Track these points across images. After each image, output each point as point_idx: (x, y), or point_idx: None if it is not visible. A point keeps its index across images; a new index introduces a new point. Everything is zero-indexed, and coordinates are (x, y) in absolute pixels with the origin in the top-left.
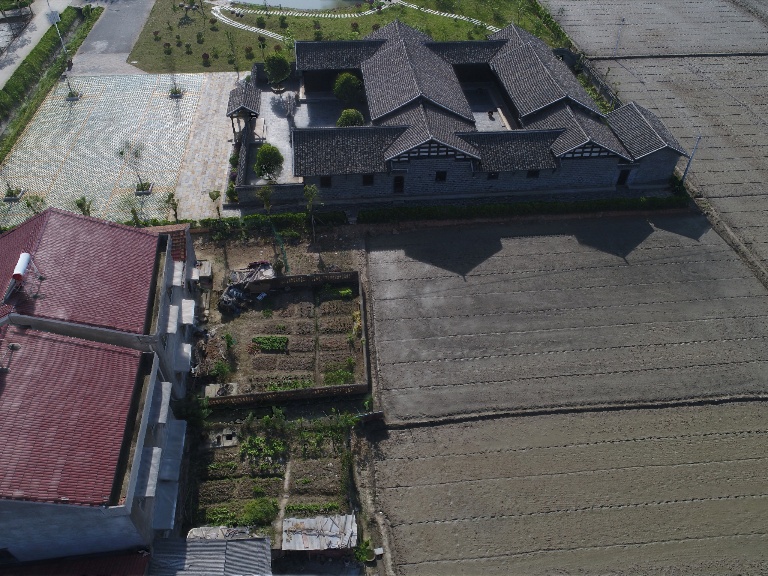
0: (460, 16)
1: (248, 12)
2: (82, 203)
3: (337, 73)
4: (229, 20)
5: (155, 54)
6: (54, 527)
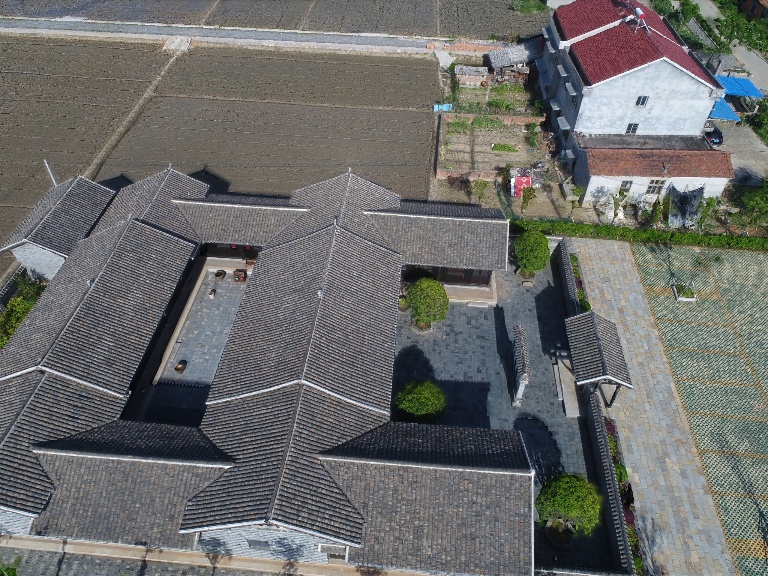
0: None
1: None
2: (707, 198)
3: None
4: None
5: None
6: None
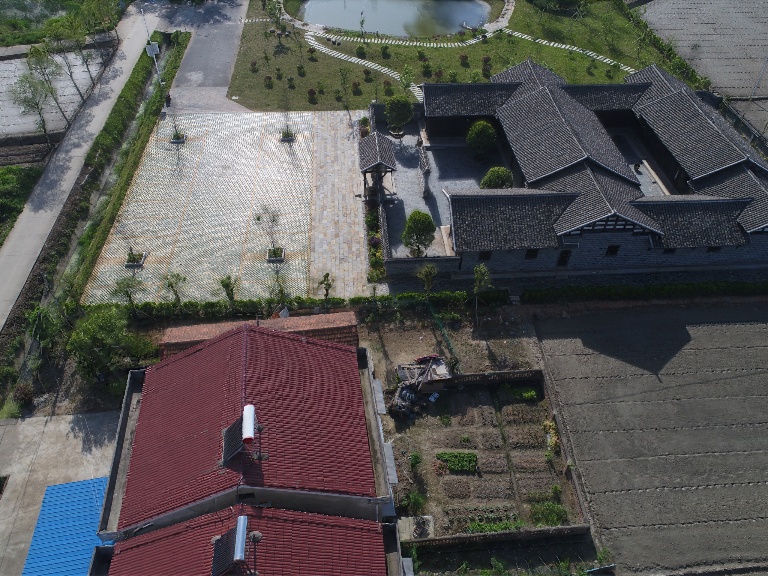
0: (572, 47)
1: (344, 39)
2: (229, 283)
3: (466, 118)
4: (326, 49)
5: (256, 88)
6: None
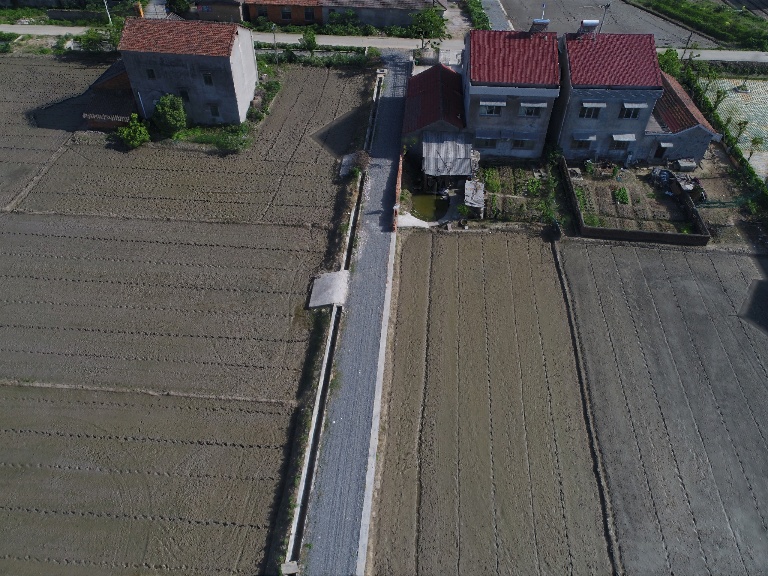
0: None
1: None
2: (720, 92)
3: None
4: None
5: None
6: None
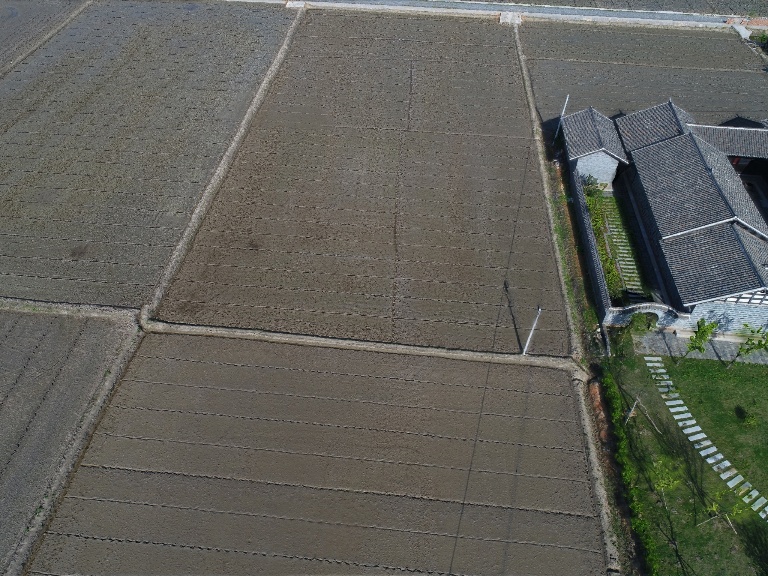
0: None
1: None
2: None
3: None
4: None
5: None
6: None
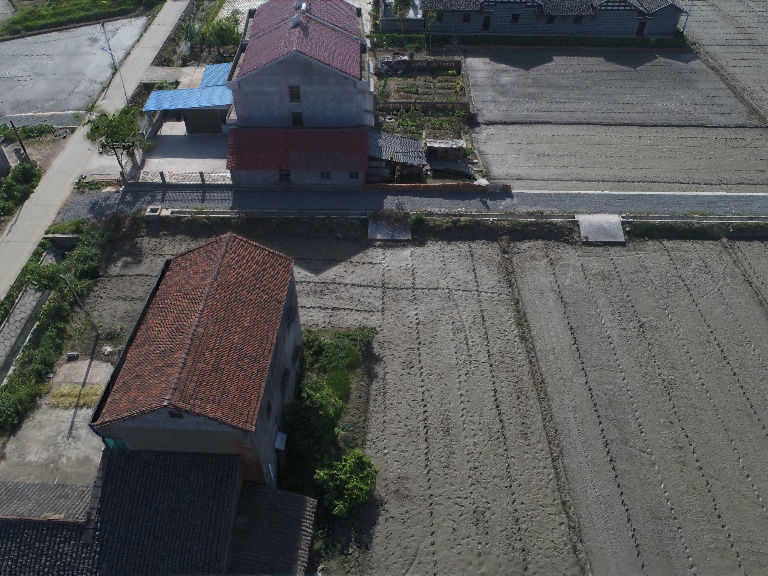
0: None
1: None
2: None
3: None
4: None
5: None
6: (329, 97)
